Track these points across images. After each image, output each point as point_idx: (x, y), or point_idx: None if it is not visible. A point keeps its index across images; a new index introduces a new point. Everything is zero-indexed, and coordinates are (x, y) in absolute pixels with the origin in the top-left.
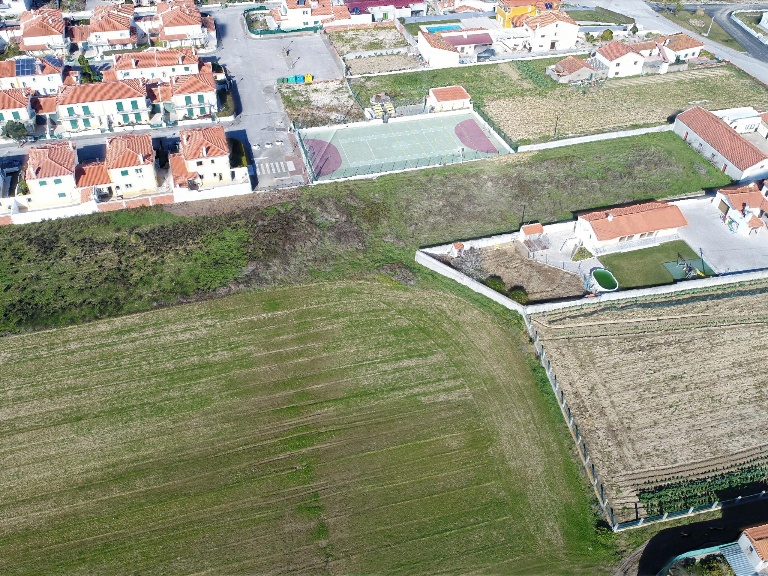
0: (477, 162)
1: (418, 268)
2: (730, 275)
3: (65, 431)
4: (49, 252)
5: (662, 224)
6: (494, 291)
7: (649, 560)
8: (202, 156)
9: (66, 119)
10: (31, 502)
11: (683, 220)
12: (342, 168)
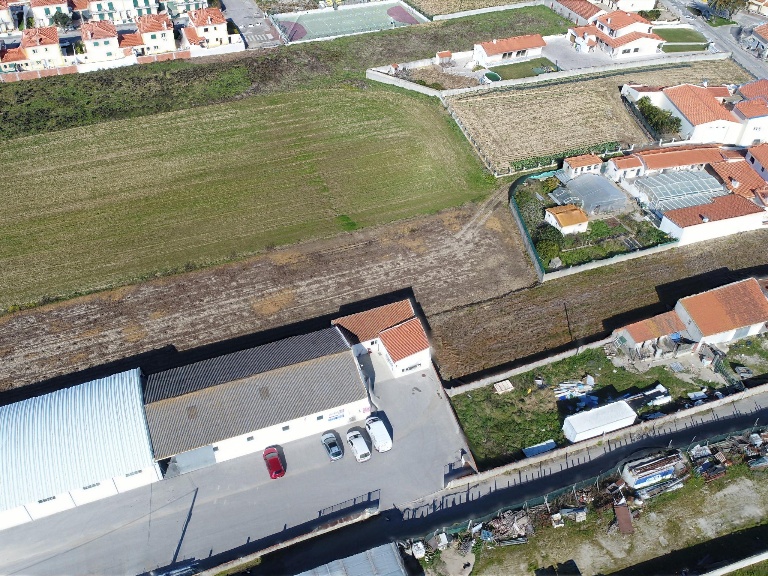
0: (405, 28)
1: (369, 81)
2: (573, 69)
3: (155, 160)
4: (110, 85)
5: (530, 45)
6: (420, 85)
7: (515, 186)
8: (208, 24)
9: (96, 13)
10: (144, 188)
11: (544, 42)
12: (308, 36)
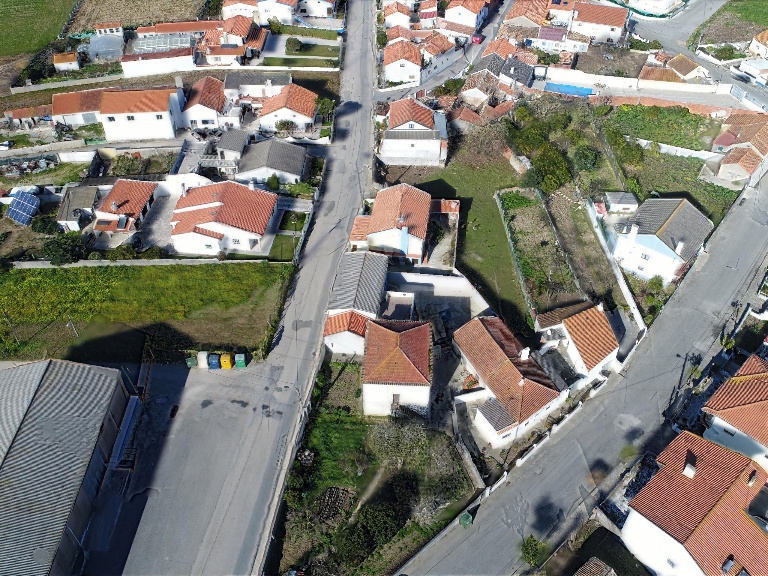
0: None
1: None
2: None
3: None
4: None
5: None
6: None
7: None
8: None
9: None
10: None
11: None
12: None
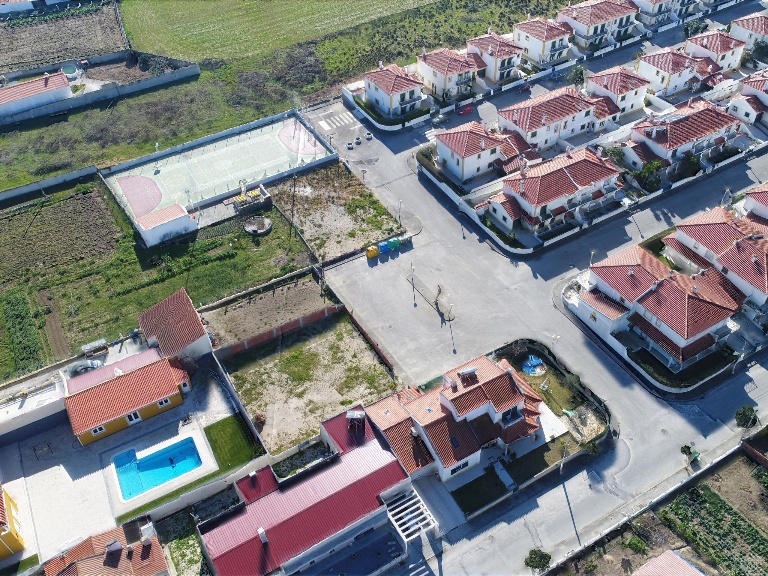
0: None
1: None
2: None
3: None
4: None
5: None
6: None
7: None
8: None
9: None
10: None
11: None
12: (277, 131)
